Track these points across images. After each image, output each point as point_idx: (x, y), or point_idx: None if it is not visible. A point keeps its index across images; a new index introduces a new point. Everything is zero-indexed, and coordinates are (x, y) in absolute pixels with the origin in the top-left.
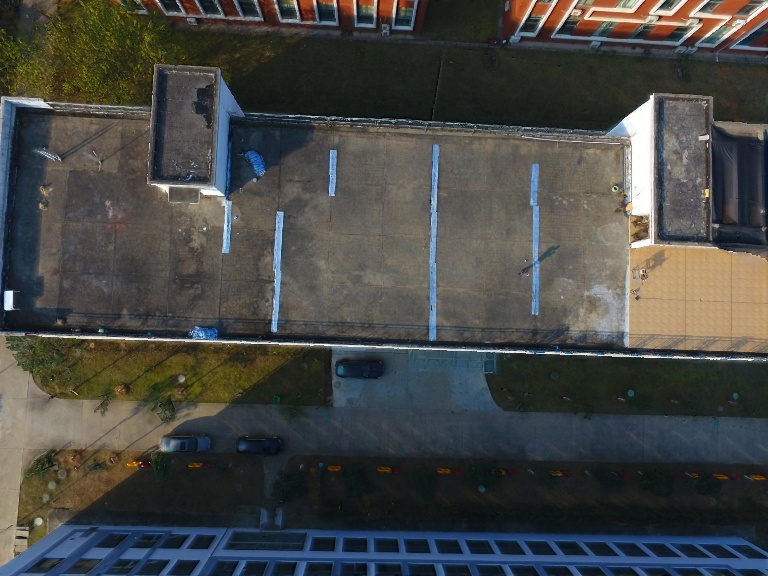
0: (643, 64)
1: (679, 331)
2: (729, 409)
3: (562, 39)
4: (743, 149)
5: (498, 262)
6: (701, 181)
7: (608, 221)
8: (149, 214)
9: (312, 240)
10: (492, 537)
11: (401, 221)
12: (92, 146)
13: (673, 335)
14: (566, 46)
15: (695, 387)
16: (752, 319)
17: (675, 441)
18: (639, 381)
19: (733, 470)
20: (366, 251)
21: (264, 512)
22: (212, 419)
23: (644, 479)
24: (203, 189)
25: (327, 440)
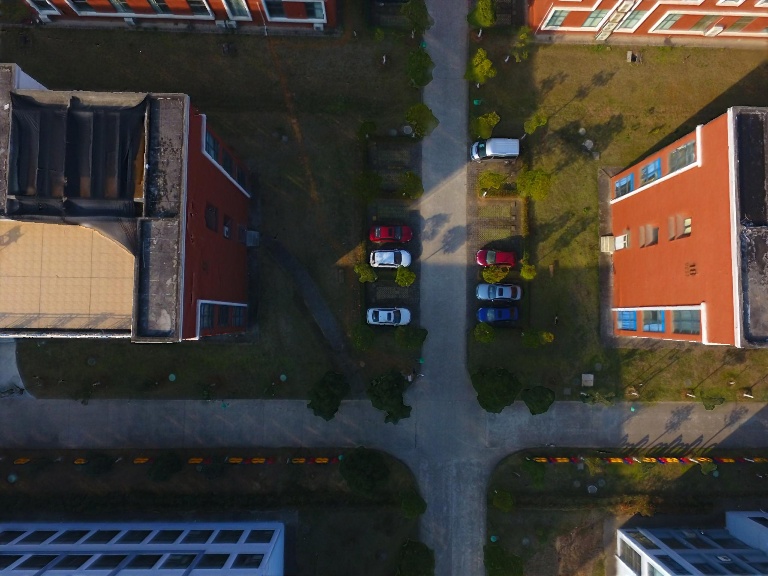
0: (187, 40)
1: (33, 309)
2: (276, 391)
3: (91, 16)
4: (46, 117)
5: None
6: (4, 152)
7: None
8: None
9: None
10: (8, 528)
11: None
12: None
13: (26, 313)
14: (104, 24)
15: (240, 370)
16: (113, 295)
17: (218, 426)
18: (181, 365)
19: (279, 454)
20: None
21: None
22: None
23: (150, 465)
24: None
25: None
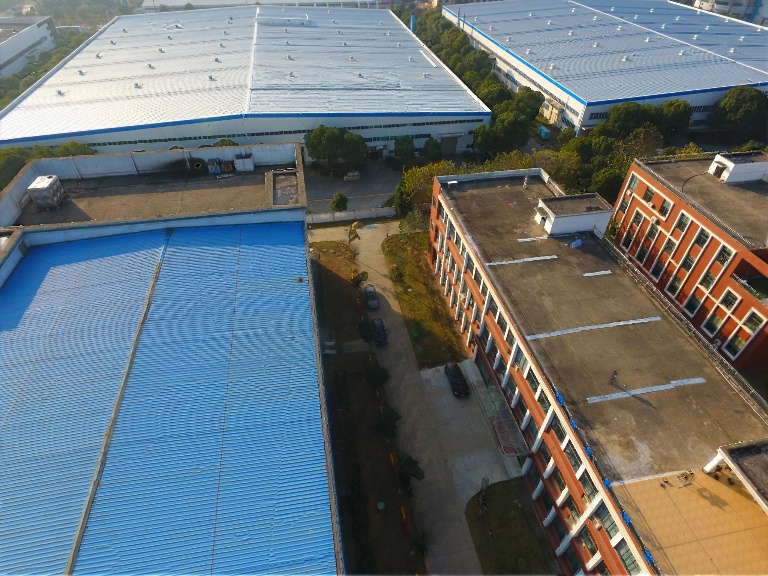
0: None
1: (662, 540)
2: None
3: None
4: None
5: (610, 368)
6: None
7: (709, 445)
8: (519, 215)
9: (550, 271)
10: None
11: (595, 308)
12: (539, 195)
13: (653, 533)
14: None
15: None
16: None
17: None
18: None
19: None
20: (562, 295)
21: (332, 343)
22: (389, 308)
23: None
24: (548, 221)
25: (393, 372)
